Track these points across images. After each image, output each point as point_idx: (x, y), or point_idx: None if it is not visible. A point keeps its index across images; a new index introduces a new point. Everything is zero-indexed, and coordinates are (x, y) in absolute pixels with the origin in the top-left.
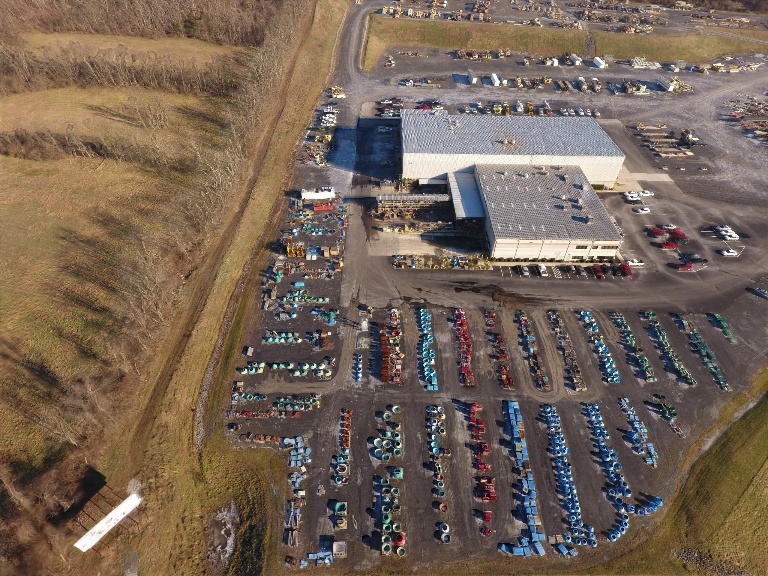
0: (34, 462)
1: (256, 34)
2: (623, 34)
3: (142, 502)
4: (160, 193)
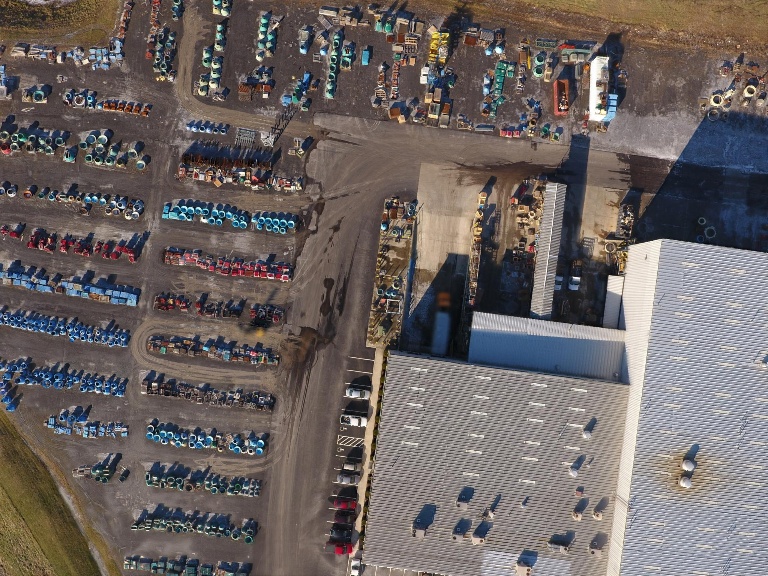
0: None
1: None
2: None
3: None
4: None
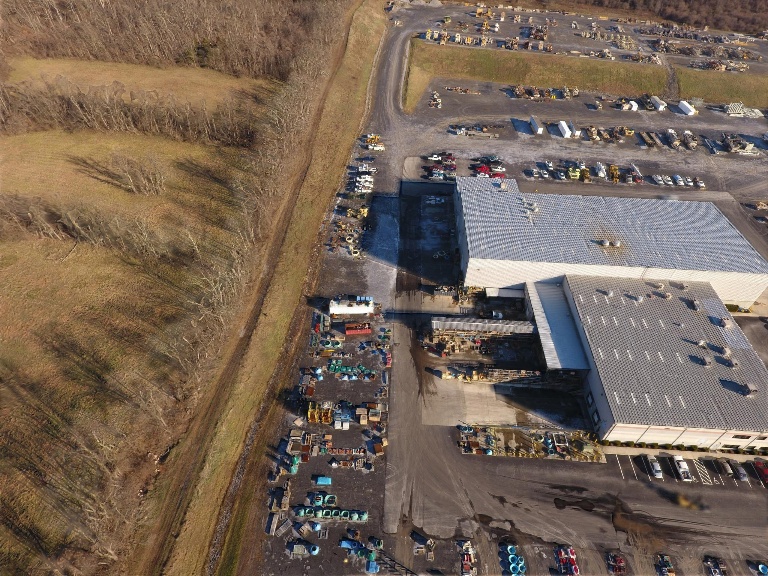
0: None
1: (280, 65)
2: (712, 72)
3: None
4: (142, 301)
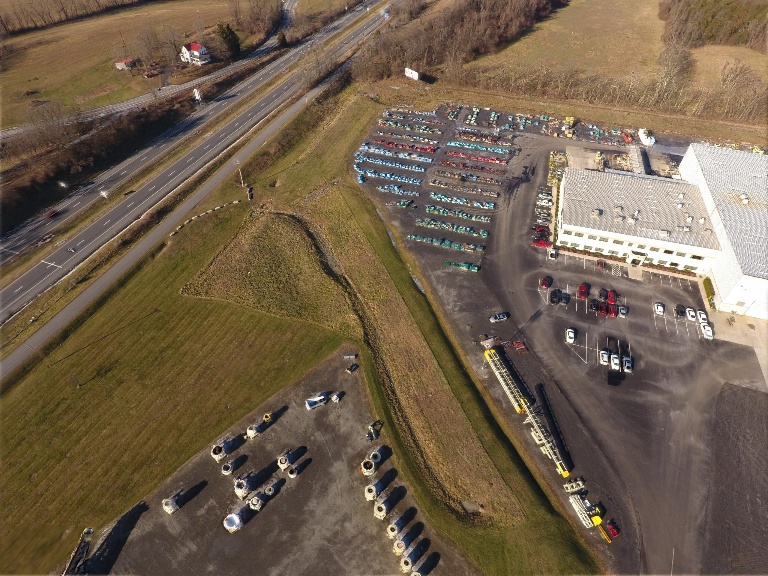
0: (443, 73)
1: None
2: None
3: (421, 89)
4: None
